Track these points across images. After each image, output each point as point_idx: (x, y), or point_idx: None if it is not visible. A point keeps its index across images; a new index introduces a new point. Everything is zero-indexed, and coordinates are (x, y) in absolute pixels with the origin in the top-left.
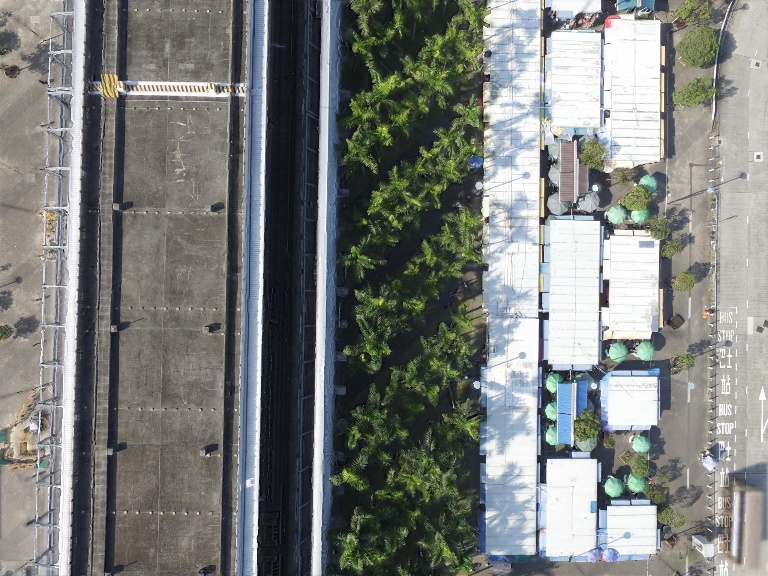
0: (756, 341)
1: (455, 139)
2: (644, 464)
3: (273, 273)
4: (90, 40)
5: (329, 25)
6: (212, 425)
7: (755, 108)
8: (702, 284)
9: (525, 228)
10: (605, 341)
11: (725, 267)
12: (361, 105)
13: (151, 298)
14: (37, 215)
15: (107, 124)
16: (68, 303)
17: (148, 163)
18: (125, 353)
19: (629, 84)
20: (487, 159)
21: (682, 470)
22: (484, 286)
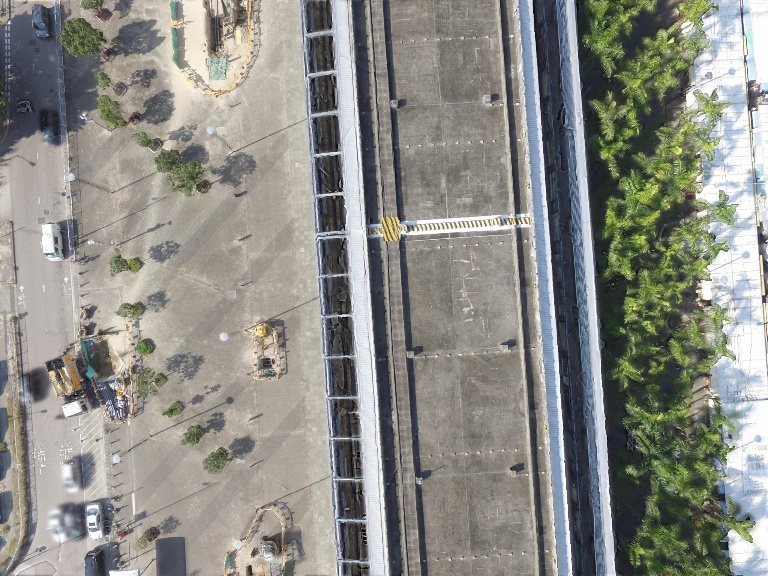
0: None
1: (700, 235)
2: None
3: None
4: (365, 182)
5: (583, 137)
6: (524, 569)
7: None
8: None
9: (748, 308)
10: None
11: None
12: (615, 214)
13: (450, 444)
14: (242, 332)
15: (392, 269)
16: (364, 456)
17: (434, 304)
18: (429, 503)
19: None
20: None
21: None
22: (711, 371)
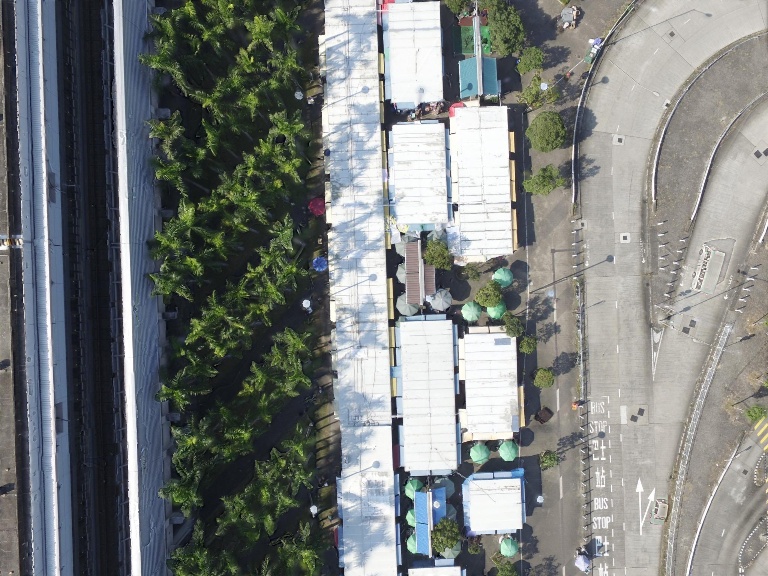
0: (631, 431)
1: (276, 258)
2: (508, 571)
3: (99, 404)
4: None
5: (125, 157)
6: None
7: (619, 187)
8: (570, 374)
9: (374, 332)
10: (465, 443)
11: (594, 355)
12: (168, 235)
13: None
14: None
15: None
16: None
17: None
18: None
19: (477, 175)
20: (332, 262)
21: (557, 568)
22: (335, 394)
